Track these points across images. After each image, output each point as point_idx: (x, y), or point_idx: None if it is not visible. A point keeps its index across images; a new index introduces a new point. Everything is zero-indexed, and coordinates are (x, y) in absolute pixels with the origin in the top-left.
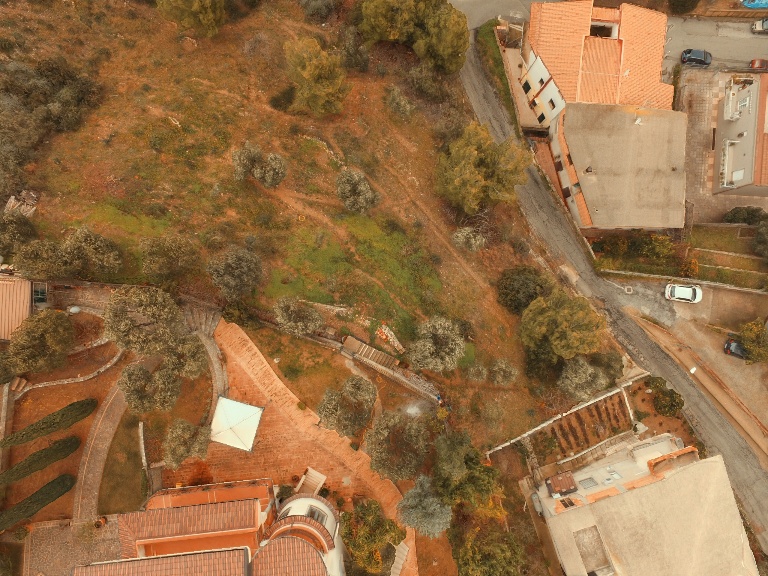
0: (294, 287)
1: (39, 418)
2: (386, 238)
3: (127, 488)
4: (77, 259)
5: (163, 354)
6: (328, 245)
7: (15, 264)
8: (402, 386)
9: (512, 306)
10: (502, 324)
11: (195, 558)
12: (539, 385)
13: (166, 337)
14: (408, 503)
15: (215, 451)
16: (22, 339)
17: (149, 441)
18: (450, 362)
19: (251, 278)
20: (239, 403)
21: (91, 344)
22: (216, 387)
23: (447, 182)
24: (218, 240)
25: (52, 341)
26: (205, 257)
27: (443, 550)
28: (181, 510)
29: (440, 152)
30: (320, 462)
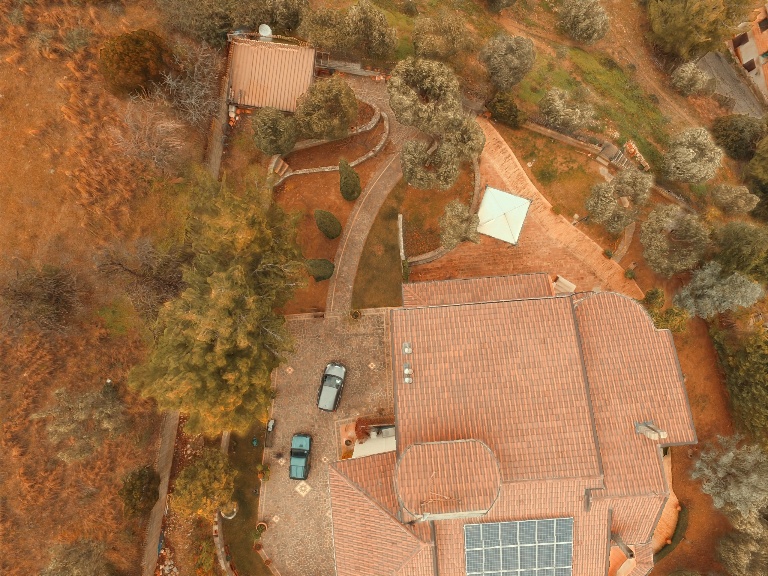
0: (542, 96)
1: (295, 207)
2: (608, 72)
3: (383, 282)
4: (357, 33)
5: (444, 130)
6: (559, 69)
7: (302, 29)
8: (657, 195)
9: (732, 148)
10: (723, 165)
11: (519, 304)
12: (766, 223)
13: (455, 108)
14: (705, 282)
15: (463, 256)
16: (317, 97)
17: (407, 235)
18: (712, 169)
19: (530, 61)
20: (507, 194)
21: (356, 129)
22: (478, 181)
23: (667, 21)
24: (472, 41)
25: (346, 102)
26: (461, 56)
27: (692, 367)
28: (470, 282)
29: (642, 5)
30: (570, 270)
